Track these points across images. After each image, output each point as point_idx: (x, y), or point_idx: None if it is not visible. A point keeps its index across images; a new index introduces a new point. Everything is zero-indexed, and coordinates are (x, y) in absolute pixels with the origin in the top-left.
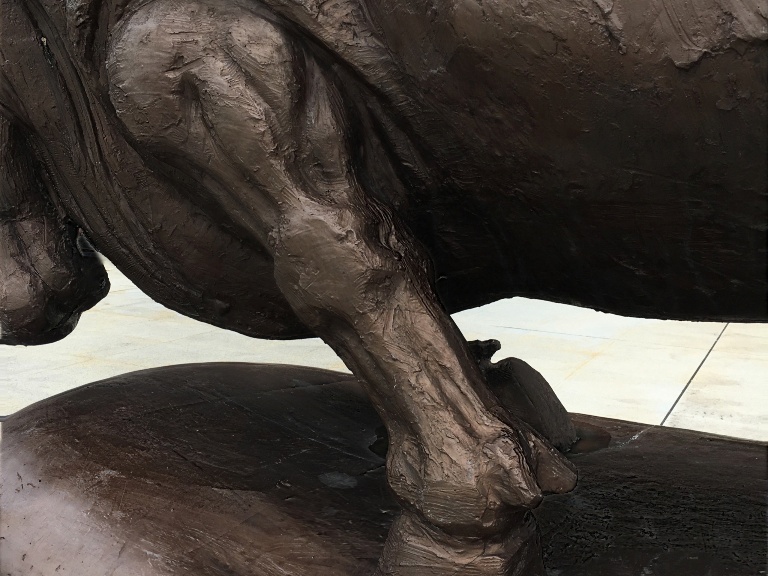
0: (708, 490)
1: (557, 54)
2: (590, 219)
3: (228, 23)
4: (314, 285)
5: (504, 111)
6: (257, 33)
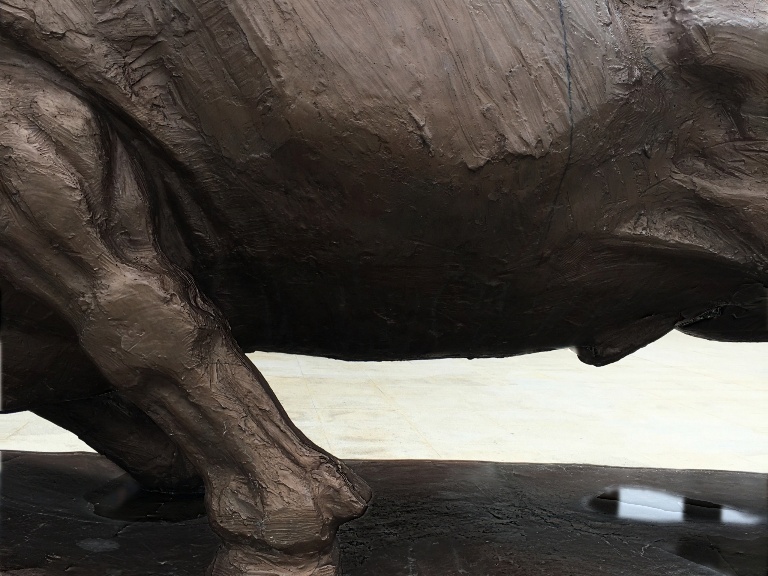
0: (405, 497)
1: (379, 152)
2: (368, 280)
3: (31, 92)
4: (139, 346)
5: (319, 193)
6: (65, 105)
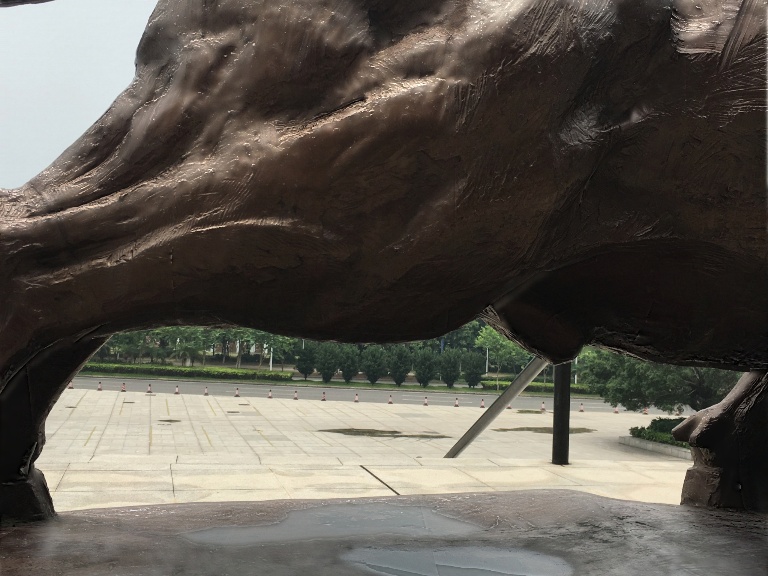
0: (760, 537)
1: None
2: None
3: None
4: None
5: None
6: None
